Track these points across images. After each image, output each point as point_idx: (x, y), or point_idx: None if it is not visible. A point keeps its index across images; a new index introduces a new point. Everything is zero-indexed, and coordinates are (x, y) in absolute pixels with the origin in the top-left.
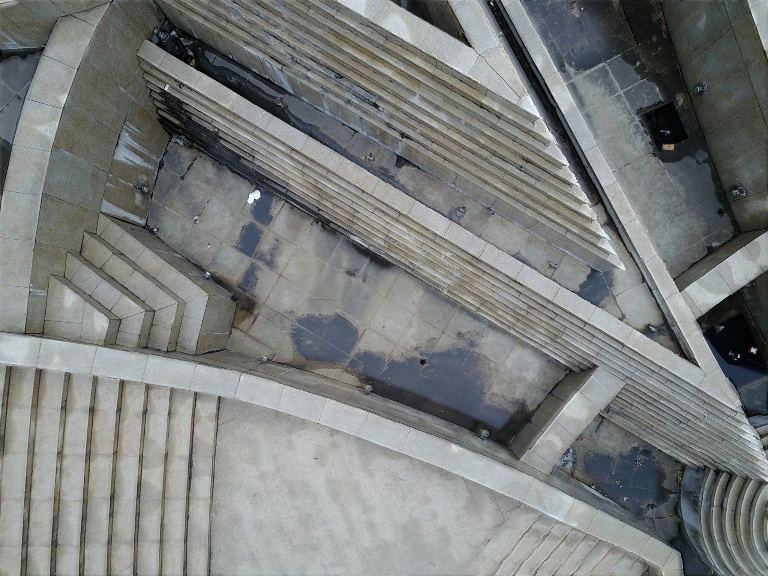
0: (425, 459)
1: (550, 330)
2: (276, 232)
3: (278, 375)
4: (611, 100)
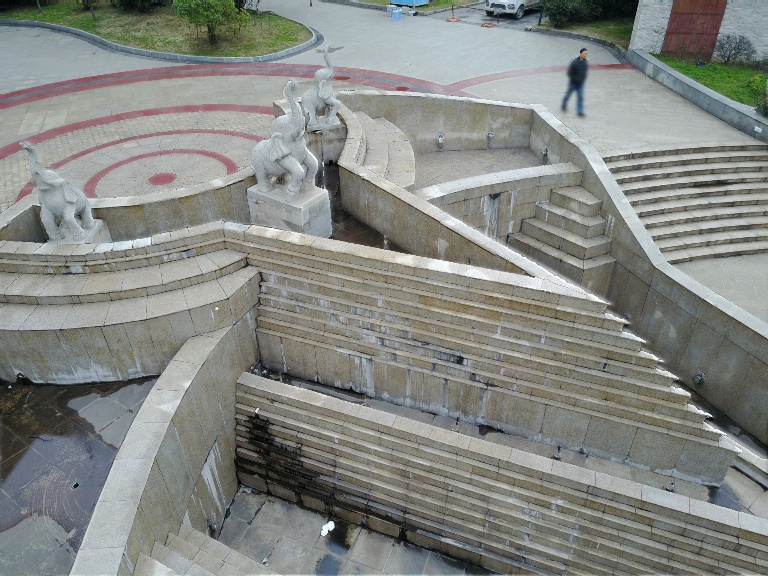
0: None
1: (703, 575)
2: (356, 560)
3: None
4: None
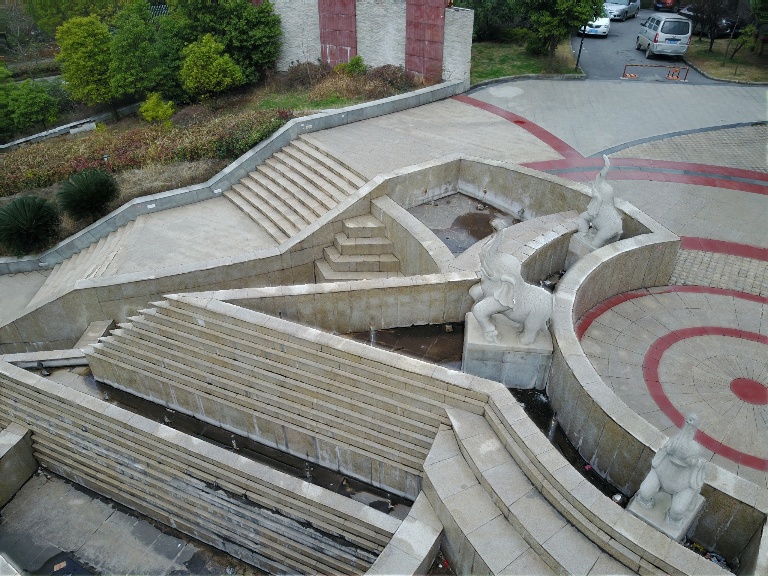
0: (167, 268)
1: None
2: None
3: (270, 279)
4: (130, 568)
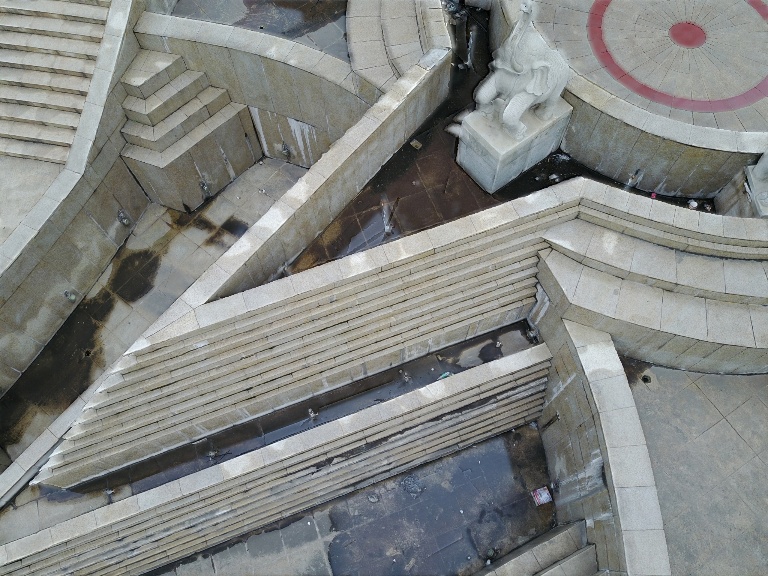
0: None
1: None
2: None
3: (88, 213)
4: None
